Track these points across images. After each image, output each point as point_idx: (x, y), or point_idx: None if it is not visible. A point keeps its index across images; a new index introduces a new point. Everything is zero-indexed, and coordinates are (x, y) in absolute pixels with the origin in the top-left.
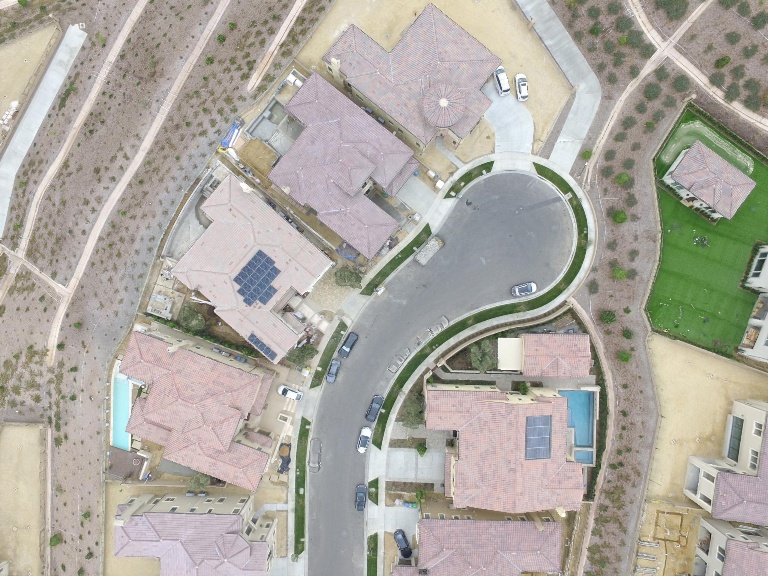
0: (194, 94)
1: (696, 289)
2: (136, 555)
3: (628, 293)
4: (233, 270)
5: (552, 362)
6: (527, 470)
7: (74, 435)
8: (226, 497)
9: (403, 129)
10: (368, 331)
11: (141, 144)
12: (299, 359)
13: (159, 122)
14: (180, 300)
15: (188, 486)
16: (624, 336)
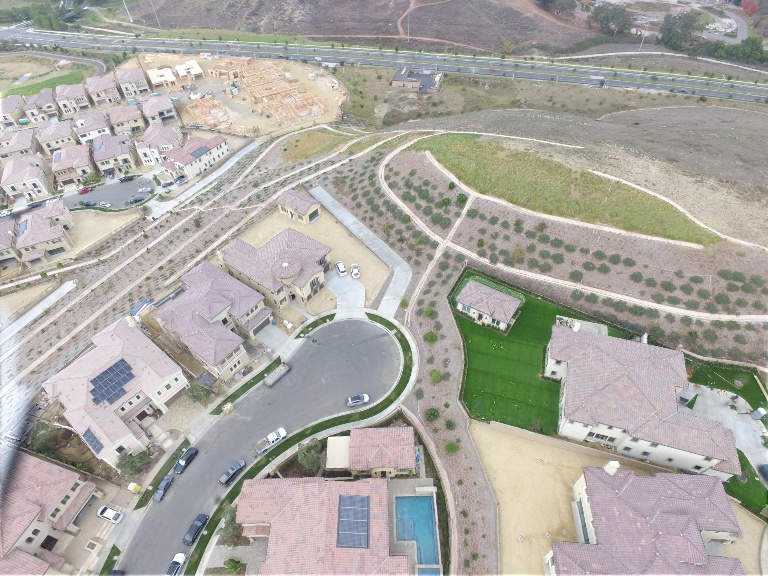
0: (128, 296)
1: (503, 382)
2: None
3: (446, 391)
4: (94, 373)
5: (376, 452)
6: (339, 561)
7: None
8: None
9: (260, 287)
10: (209, 447)
11: (75, 329)
12: (128, 465)
13: (96, 316)
14: None
15: None
16: (447, 427)
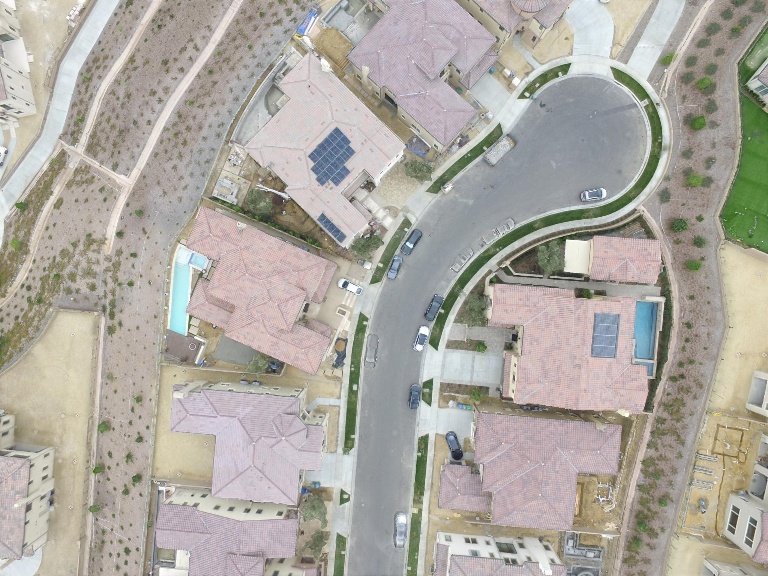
0: None
1: None
2: (192, 431)
3: (702, 201)
4: (309, 146)
5: (621, 265)
6: (592, 367)
7: (129, 321)
8: (280, 387)
9: (486, 17)
10: (432, 230)
11: (212, 36)
12: (364, 248)
13: (230, 15)
14: (246, 187)
15: (242, 375)
16: (695, 244)
